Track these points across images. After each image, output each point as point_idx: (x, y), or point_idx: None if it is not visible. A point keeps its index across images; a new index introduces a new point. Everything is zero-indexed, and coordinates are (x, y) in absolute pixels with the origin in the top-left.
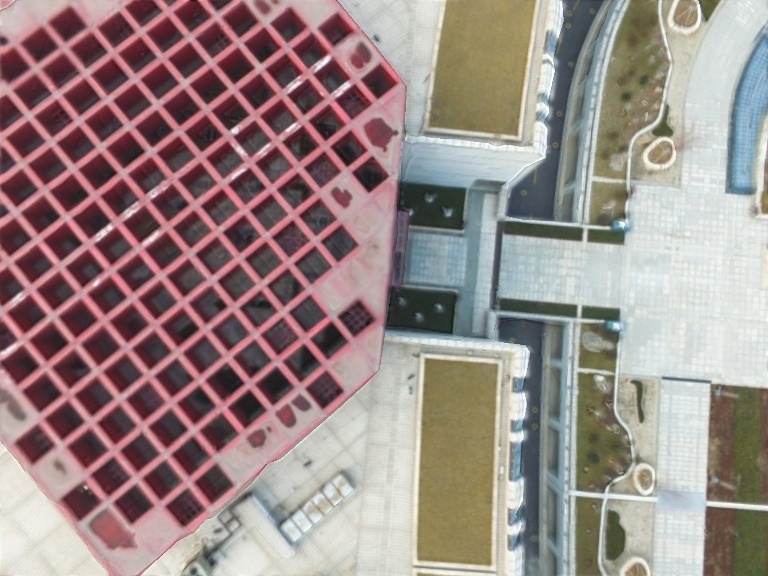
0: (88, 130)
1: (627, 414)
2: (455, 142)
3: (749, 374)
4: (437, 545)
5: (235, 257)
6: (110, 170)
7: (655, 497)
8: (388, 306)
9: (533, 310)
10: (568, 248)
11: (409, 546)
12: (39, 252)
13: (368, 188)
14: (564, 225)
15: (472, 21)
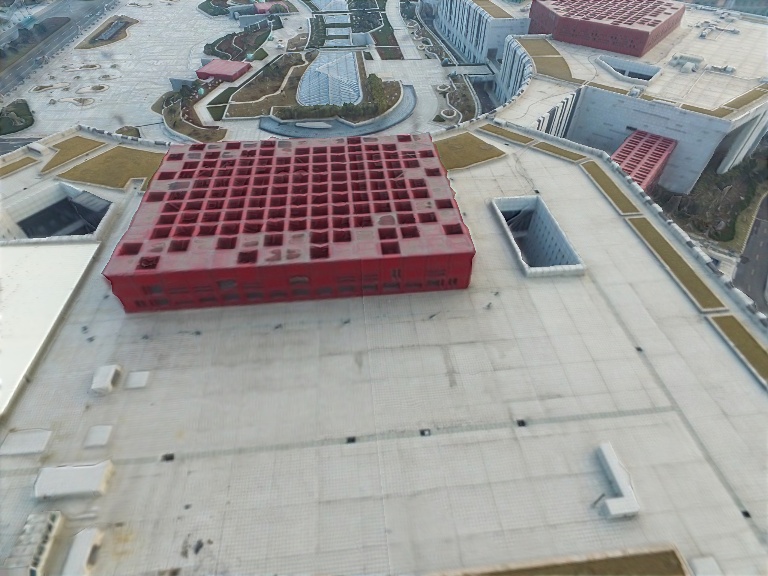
0: (629, 8)
1: (431, 55)
2: (535, 35)
3: (392, 61)
4: (495, 7)
5: (578, 2)
6: (618, 6)
7: (416, 46)
8: (537, 1)
9: (473, 64)
10: (467, 73)
11: (501, 7)
12: (621, 0)
13: (556, 8)
14: (472, 75)
15: (547, 50)
